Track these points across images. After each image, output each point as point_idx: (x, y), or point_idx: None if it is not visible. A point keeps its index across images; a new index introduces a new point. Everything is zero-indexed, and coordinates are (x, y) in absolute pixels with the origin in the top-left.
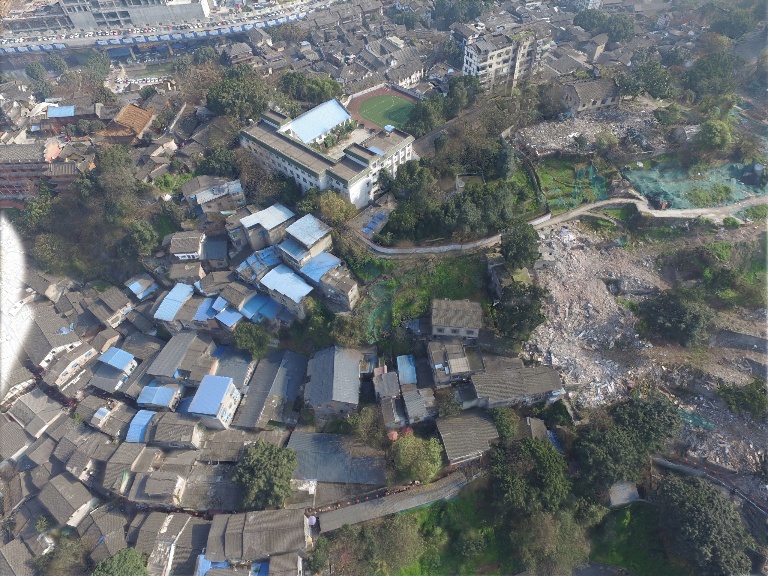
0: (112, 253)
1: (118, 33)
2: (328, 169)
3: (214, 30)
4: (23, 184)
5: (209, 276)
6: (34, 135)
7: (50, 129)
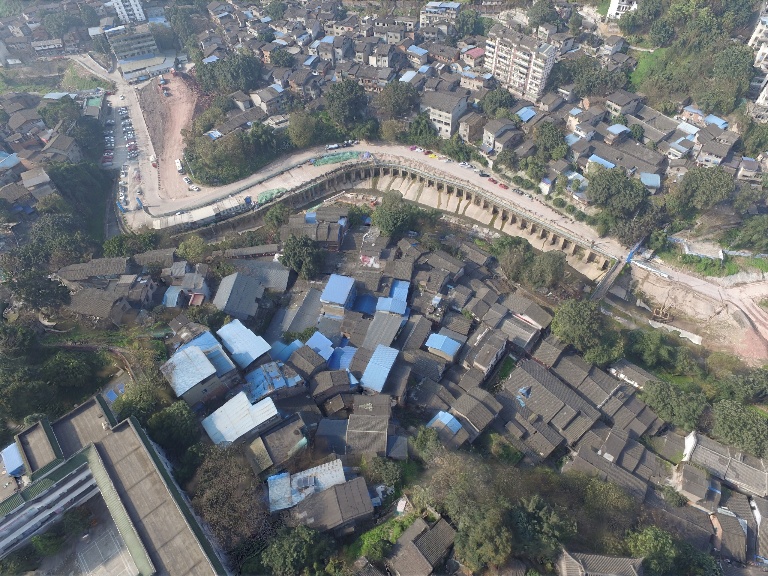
0: None
1: None
2: (110, 426)
3: None
4: None
5: (337, 382)
6: None
7: None
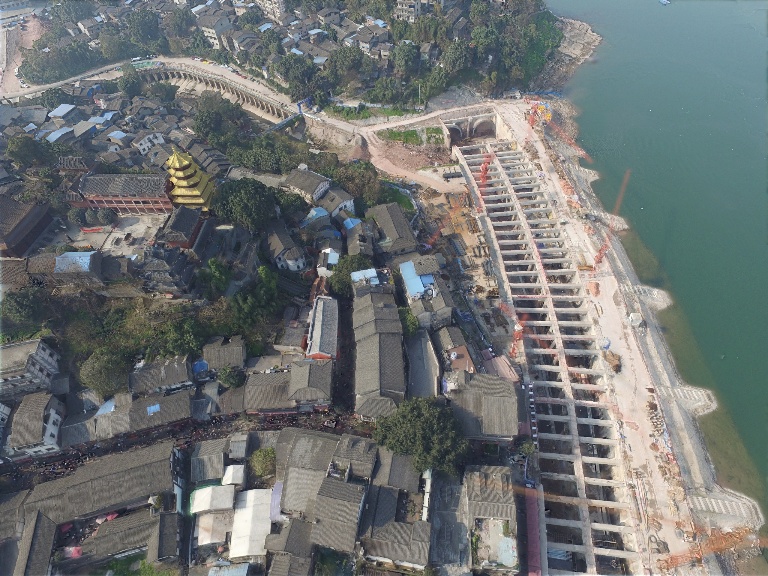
0: None
1: None
2: None
3: None
4: None
5: None
6: None
7: None
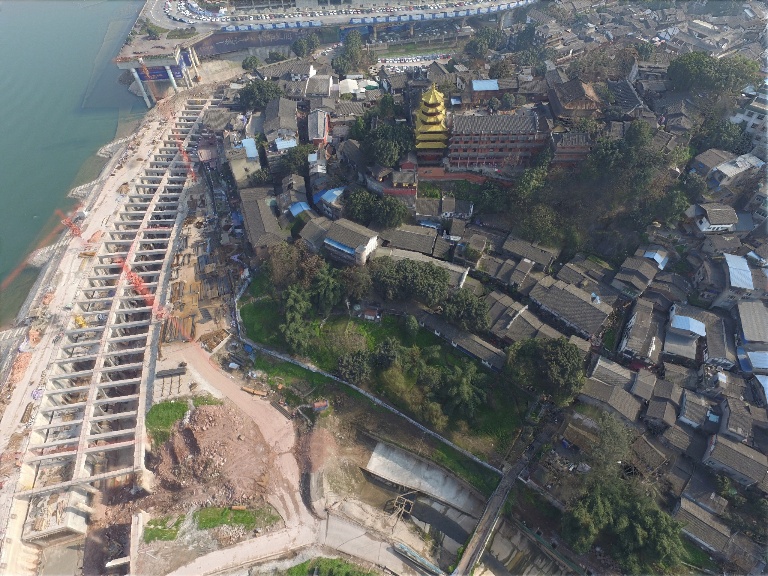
0: (602, 225)
1: (361, 12)
2: None
3: (464, 11)
4: (490, 156)
5: (765, 246)
6: (450, 108)
7: (470, 103)
